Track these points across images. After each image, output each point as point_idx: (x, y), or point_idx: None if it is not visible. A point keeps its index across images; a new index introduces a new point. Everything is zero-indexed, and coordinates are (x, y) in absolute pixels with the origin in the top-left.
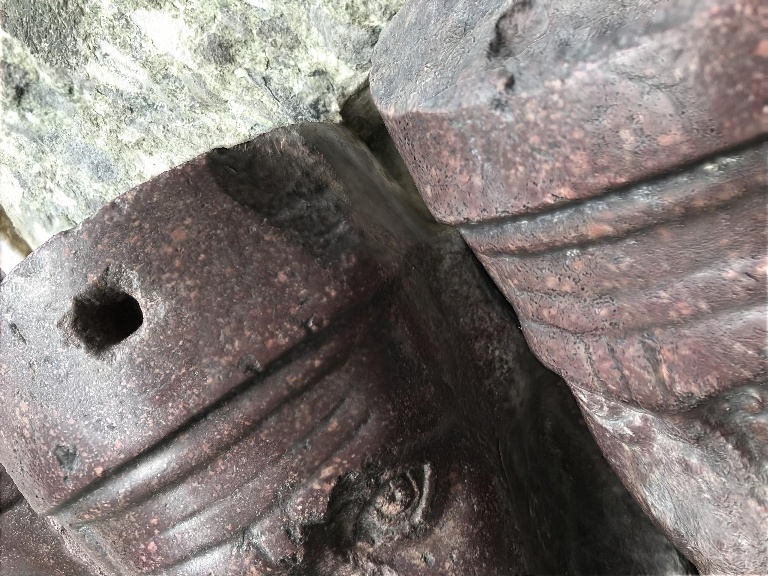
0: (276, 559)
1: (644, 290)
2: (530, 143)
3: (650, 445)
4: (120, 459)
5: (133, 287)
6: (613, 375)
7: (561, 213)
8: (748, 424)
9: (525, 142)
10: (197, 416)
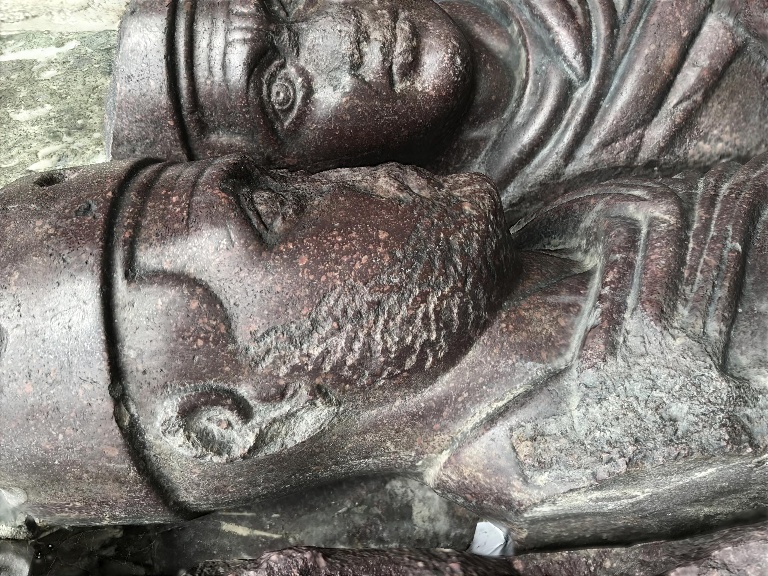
0: None
1: (214, 6)
2: (148, 6)
3: (307, 72)
4: (116, 182)
5: (62, 172)
6: (244, 32)
7: (177, 16)
8: (291, 19)
9: (147, 8)
10: (140, 165)
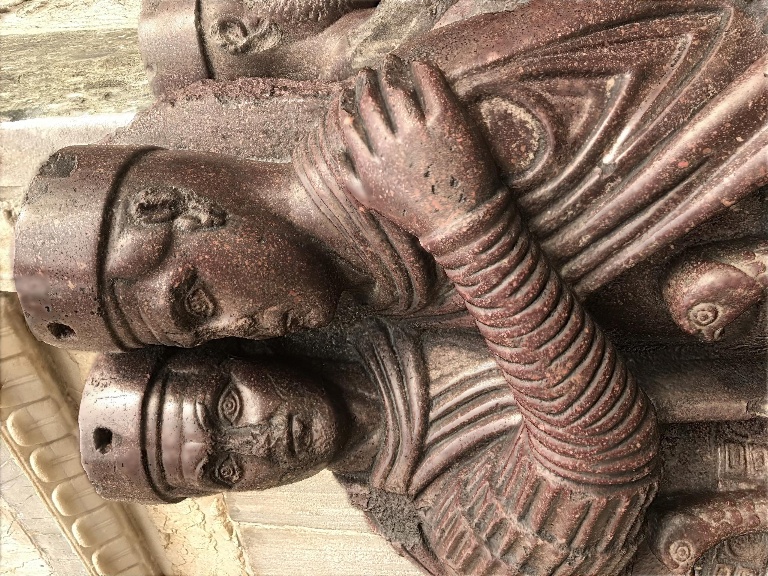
0: None
1: None
2: None
3: None
4: None
5: None
6: None
7: None
8: None
9: None
10: None
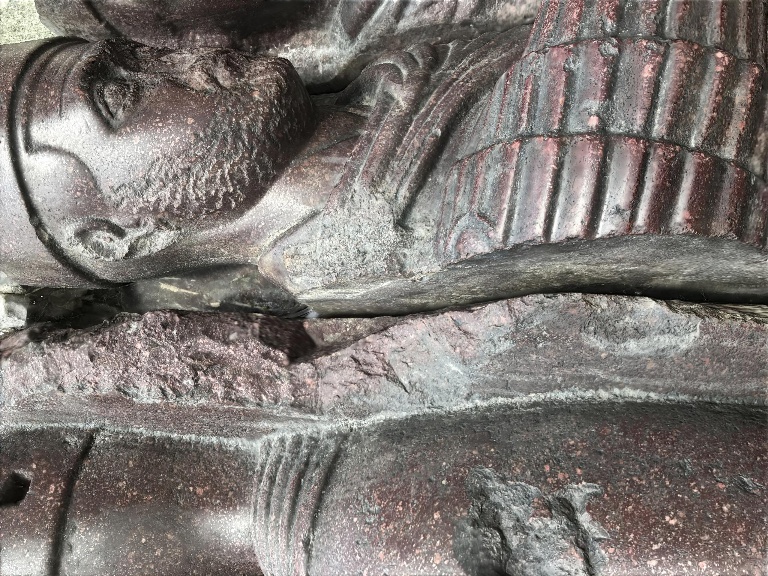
0: (97, 54)
1: None
2: None
3: None
4: (15, 78)
5: None
6: None
7: None
8: None
9: None
10: (35, 56)
